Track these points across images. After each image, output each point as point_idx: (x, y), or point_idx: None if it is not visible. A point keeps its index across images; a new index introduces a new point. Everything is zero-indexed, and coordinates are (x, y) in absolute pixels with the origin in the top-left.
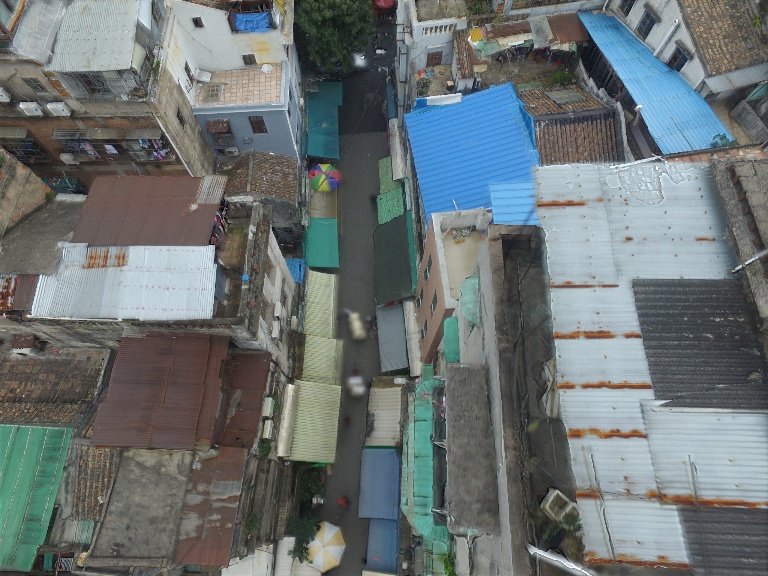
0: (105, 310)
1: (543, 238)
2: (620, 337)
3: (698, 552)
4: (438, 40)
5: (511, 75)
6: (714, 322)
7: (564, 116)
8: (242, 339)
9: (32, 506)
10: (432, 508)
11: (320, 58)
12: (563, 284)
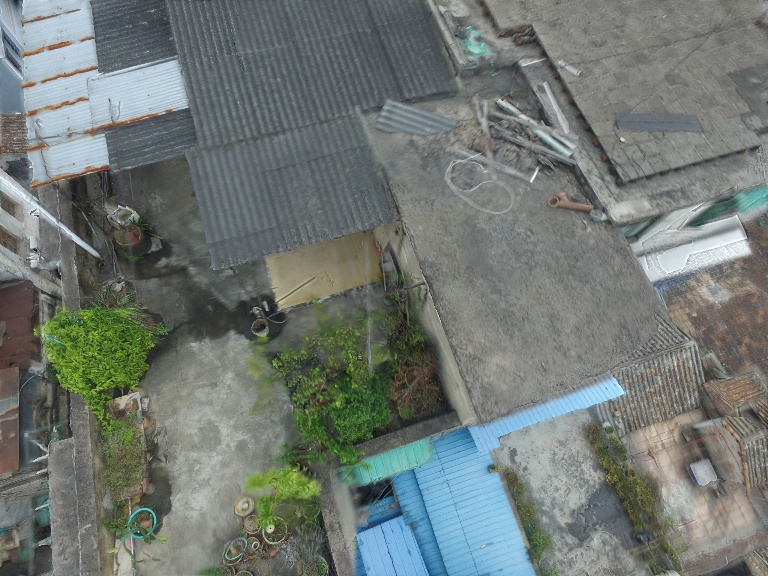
0: None
1: None
2: (77, 42)
3: (116, 155)
4: None
5: None
6: (151, 14)
7: None
8: None
9: None
10: None
11: None
12: (34, 19)
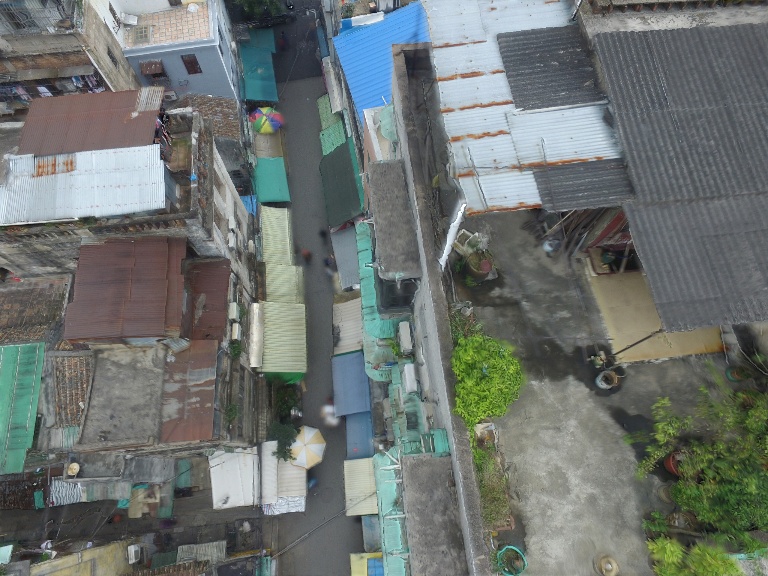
0: (60, 211)
1: None
2: (489, 74)
3: (548, 195)
4: None
5: None
6: (559, 55)
7: None
8: (199, 241)
9: (15, 416)
10: None
11: (246, 2)
12: (443, 45)
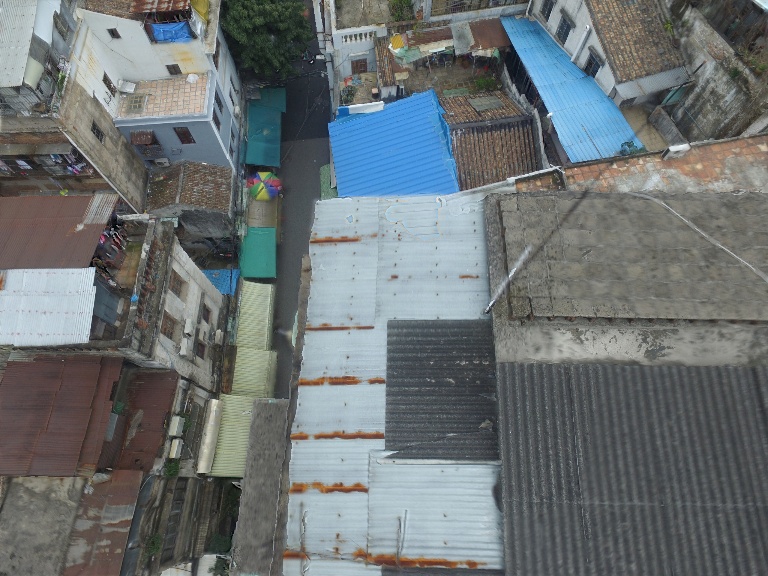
0: None
1: None
2: (364, 383)
3: None
4: (360, 48)
5: (431, 83)
6: (460, 366)
7: (481, 124)
8: (138, 359)
9: None
10: None
11: (258, 65)
12: (319, 326)
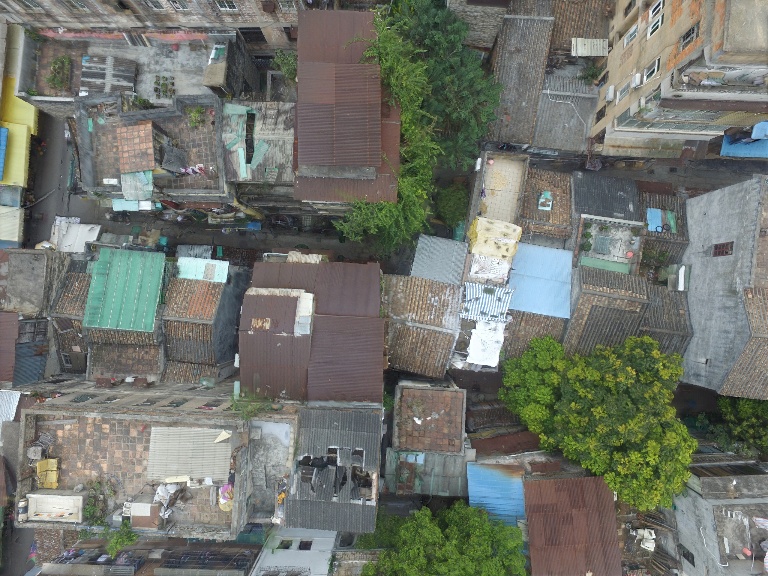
0: None
1: None
2: None
3: None
4: None
5: None
6: None
7: None
8: None
9: (104, 282)
10: None
11: None
12: None
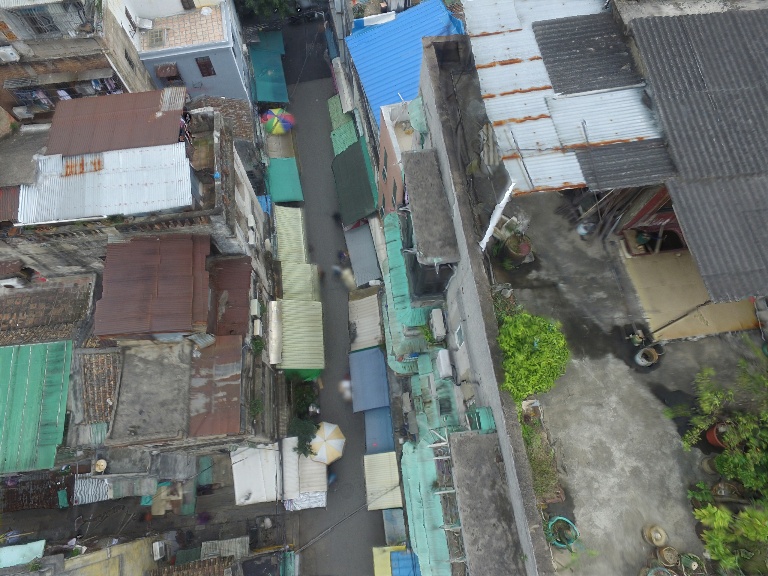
0: (89, 209)
1: (468, 43)
2: (526, 61)
3: (592, 175)
4: None
5: None
6: (594, 41)
7: None
8: (222, 238)
9: (45, 412)
10: (404, 250)
11: (257, 6)
12: (479, 34)
